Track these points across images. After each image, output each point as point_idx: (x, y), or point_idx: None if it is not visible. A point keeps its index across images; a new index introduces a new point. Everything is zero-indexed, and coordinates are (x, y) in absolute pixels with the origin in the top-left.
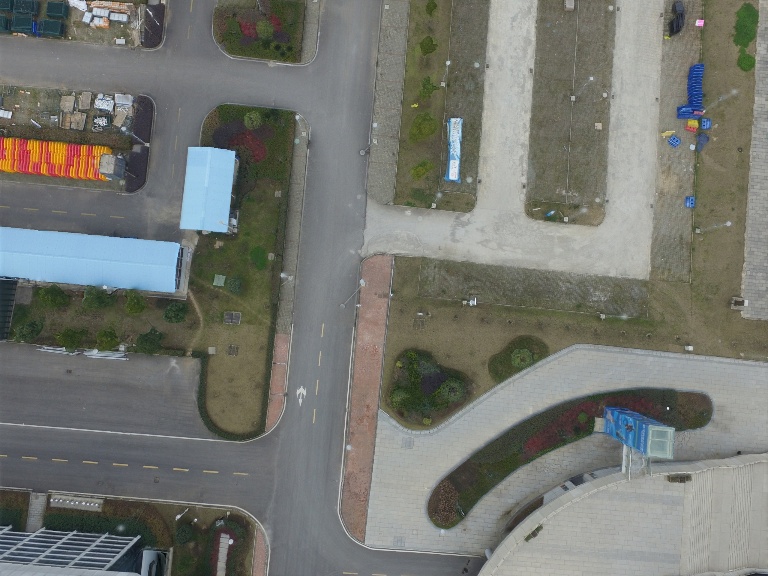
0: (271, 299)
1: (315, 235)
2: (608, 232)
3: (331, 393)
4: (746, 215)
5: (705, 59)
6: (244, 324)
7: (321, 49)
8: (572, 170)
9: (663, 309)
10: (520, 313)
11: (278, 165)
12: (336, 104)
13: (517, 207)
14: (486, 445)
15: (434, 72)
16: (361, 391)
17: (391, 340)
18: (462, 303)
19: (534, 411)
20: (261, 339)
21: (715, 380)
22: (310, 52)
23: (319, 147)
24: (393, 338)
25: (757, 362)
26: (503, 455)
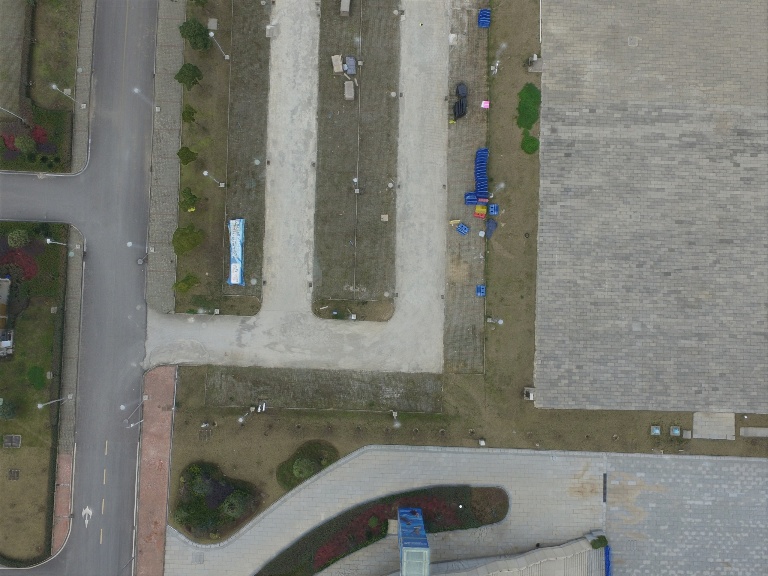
0: (50, 420)
1: (95, 350)
2: (398, 327)
3: (118, 511)
4: (535, 302)
5: (492, 142)
6: (24, 447)
7: (93, 157)
8: (359, 265)
9: (457, 402)
10: (309, 416)
11: (50, 281)
12: (111, 213)
13: (304, 307)
14: (277, 555)
15: (211, 173)
16: (148, 508)
17: (176, 454)
18: (250, 410)
19: (326, 517)
20: (42, 461)
21: (511, 473)
22: (81, 161)
23: (95, 259)
24: (178, 451)
25: (553, 451)
26: (293, 565)
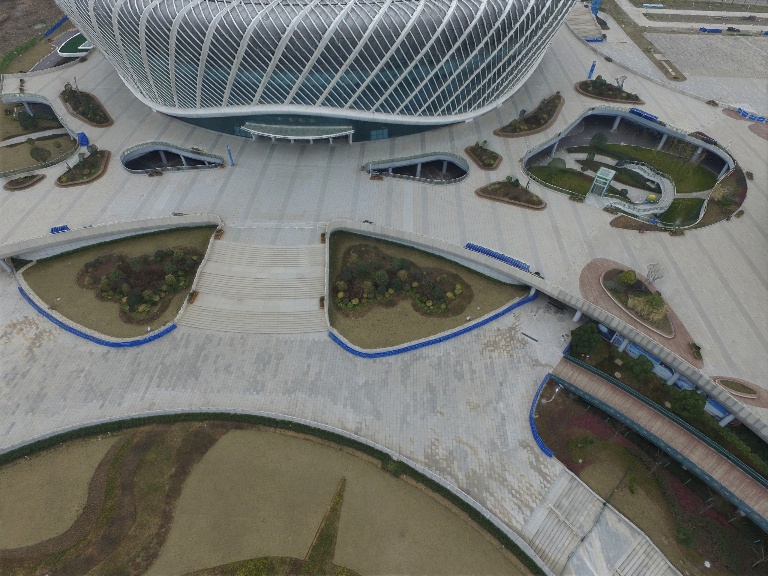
0: None
1: None
2: None
3: None
4: None
5: None
6: None
7: None
8: None
9: None
10: None
11: None
12: None
13: None
14: None
15: None
16: None
17: None
18: (608, 5)
19: None
20: None
21: None
22: None
23: None
24: None
25: None
26: None
